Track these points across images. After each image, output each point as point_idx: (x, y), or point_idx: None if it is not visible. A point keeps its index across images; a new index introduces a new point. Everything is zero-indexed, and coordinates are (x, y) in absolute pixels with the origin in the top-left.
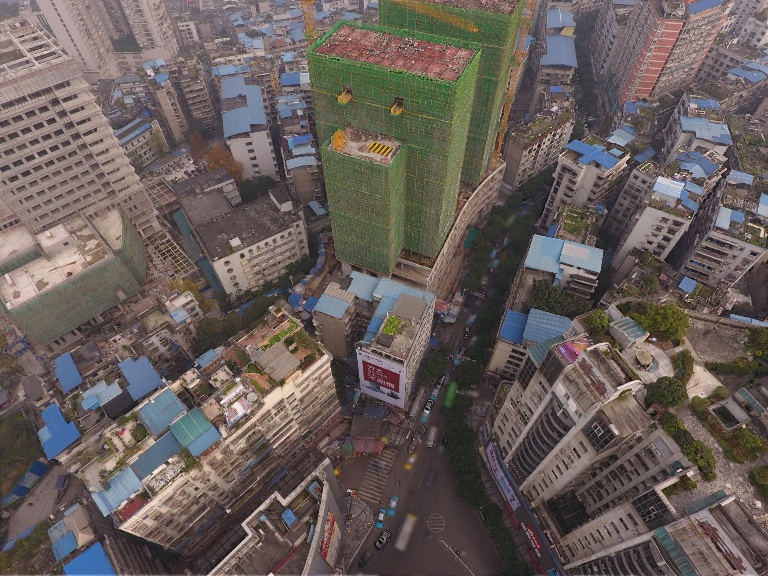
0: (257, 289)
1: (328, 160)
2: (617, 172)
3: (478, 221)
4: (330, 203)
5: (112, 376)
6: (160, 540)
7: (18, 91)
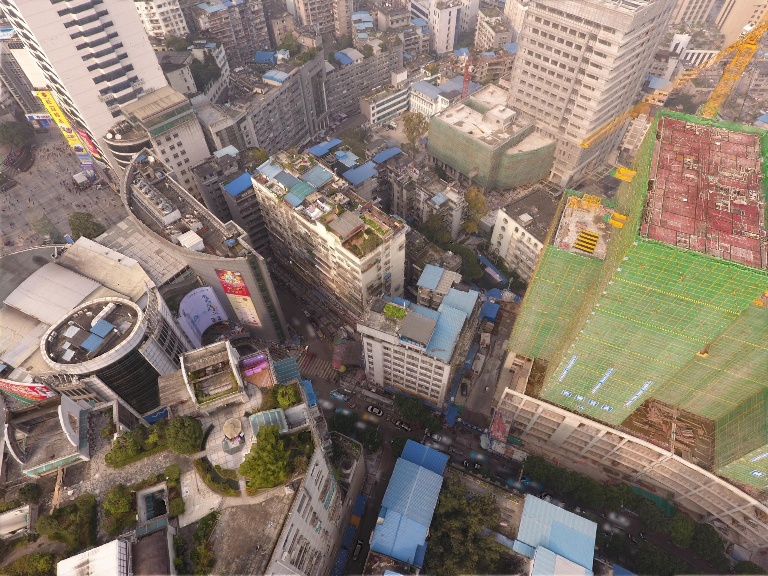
0: (508, 267)
1: None
2: None
3: (693, 515)
4: None
5: (363, 161)
6: (264, 217)
7: (581, 11)
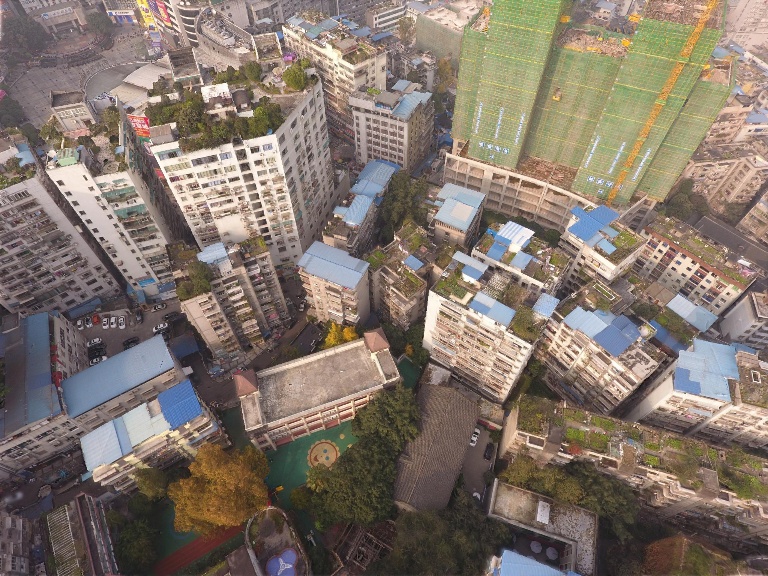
0: None
1: None
2: (591, 266)
3: None
4: None
5: None
6: None
7: None
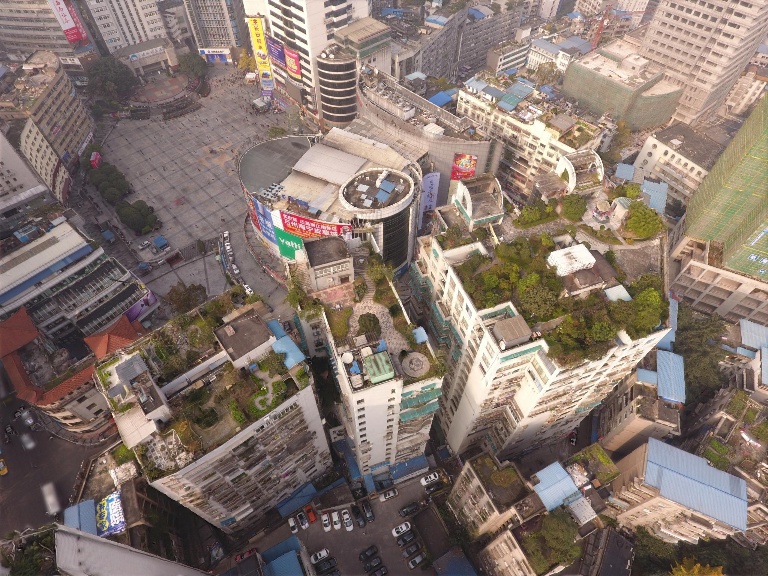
0: None
1: (762, 101)
2: None
3: None
4: (730, 144)
5: None
6: None
7: None
